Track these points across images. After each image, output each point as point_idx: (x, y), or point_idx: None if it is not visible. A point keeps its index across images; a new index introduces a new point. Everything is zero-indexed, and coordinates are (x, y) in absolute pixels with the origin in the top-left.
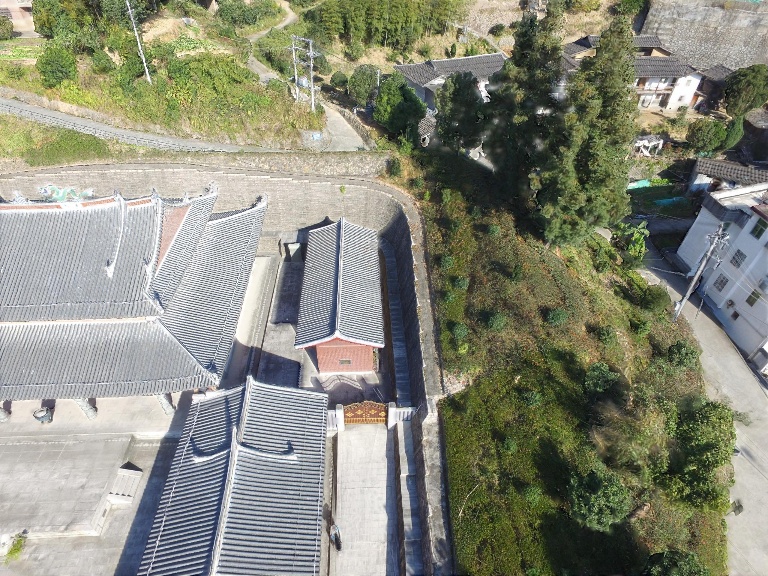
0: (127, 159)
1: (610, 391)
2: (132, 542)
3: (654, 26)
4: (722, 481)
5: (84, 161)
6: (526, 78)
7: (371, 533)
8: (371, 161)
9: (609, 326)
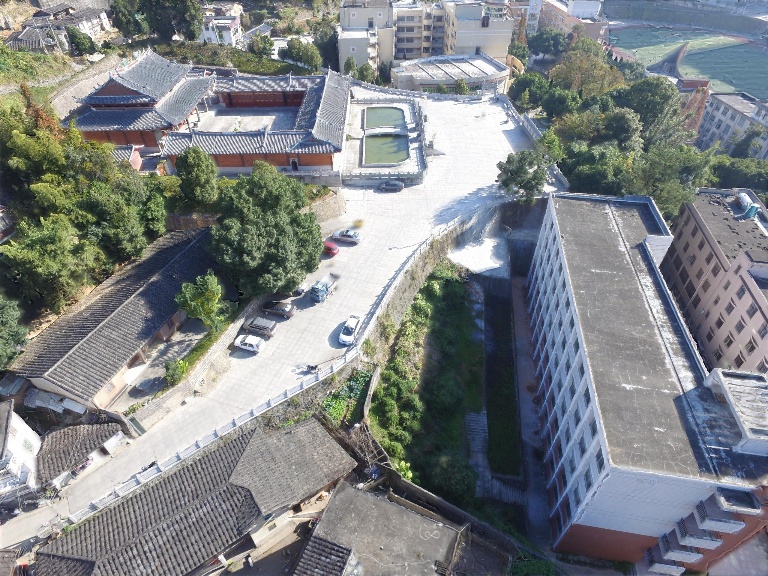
0: (58, 89)
1: None
2: None
3: (45, 1)
4: None
5: None
6: None
7: None
8: (114, 57)
9: (229, 43)
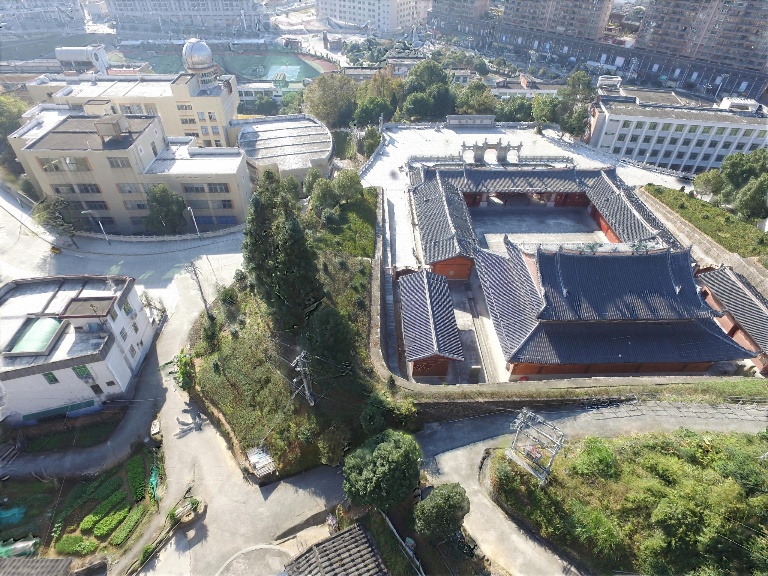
0: None
1: None
2: None
3: None
4: None
5: None
6: None
7: (402, 256)
8: None
9: None
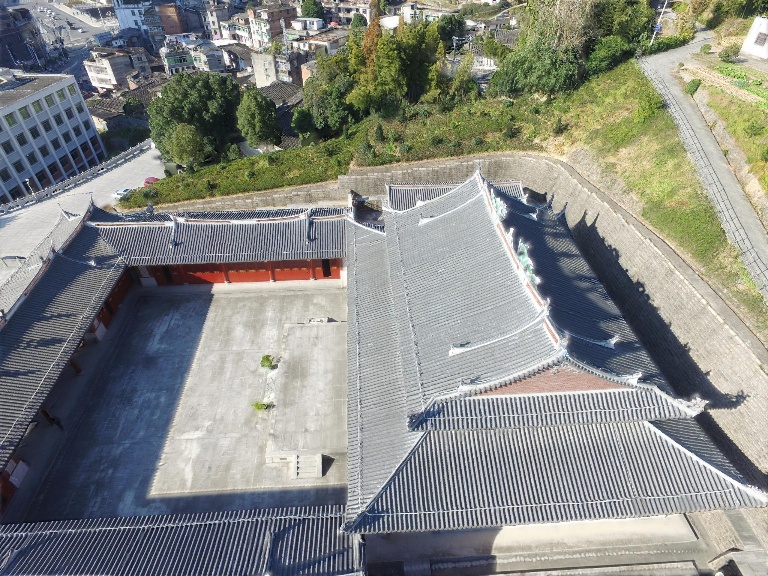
0: (715, 280)
1: None
2: (255, 494)
3: None
4: None
5: (680, 246)
6: None
7: None
8: None
9: None
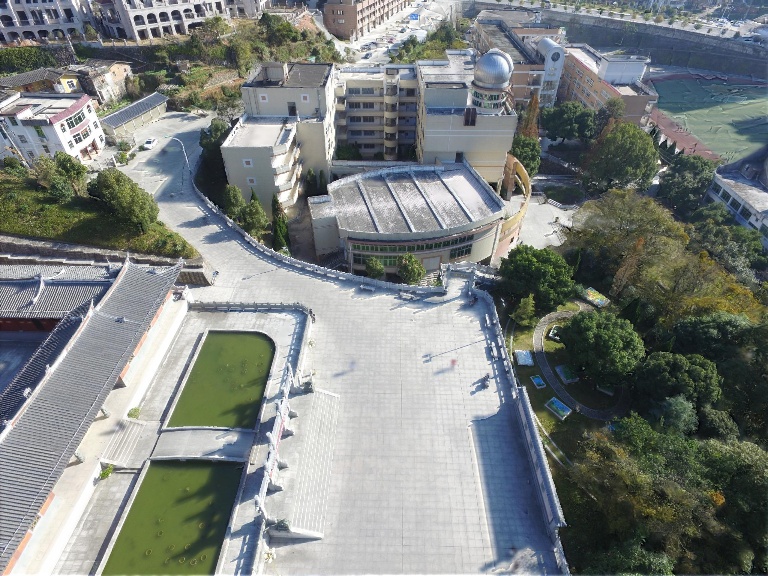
0: None
1: (33, 182)
2: None
3: None
4: (77, 162)
5: None
6: None
7: None
8: None
9: (5, 167)
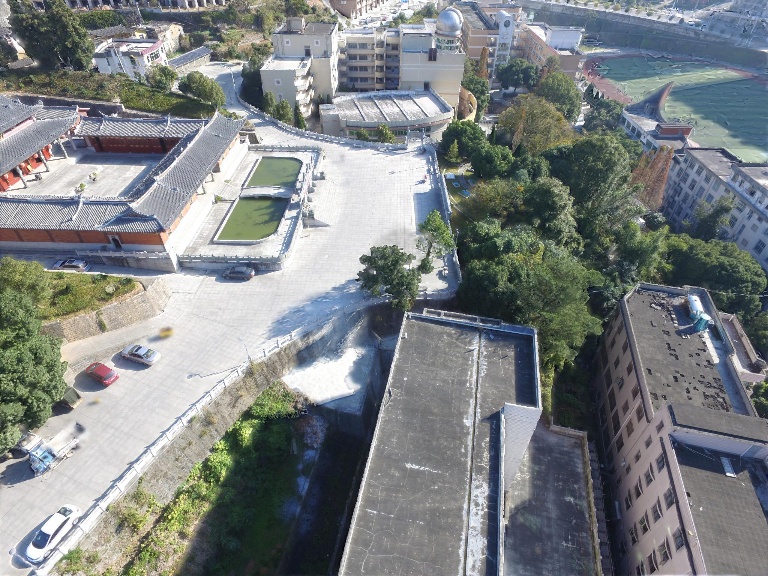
0: None
1: None
2: None
3: None
4: (171, 70)
5: None
6: (32, 16)
7: None
8: None
9: (124, 73)
